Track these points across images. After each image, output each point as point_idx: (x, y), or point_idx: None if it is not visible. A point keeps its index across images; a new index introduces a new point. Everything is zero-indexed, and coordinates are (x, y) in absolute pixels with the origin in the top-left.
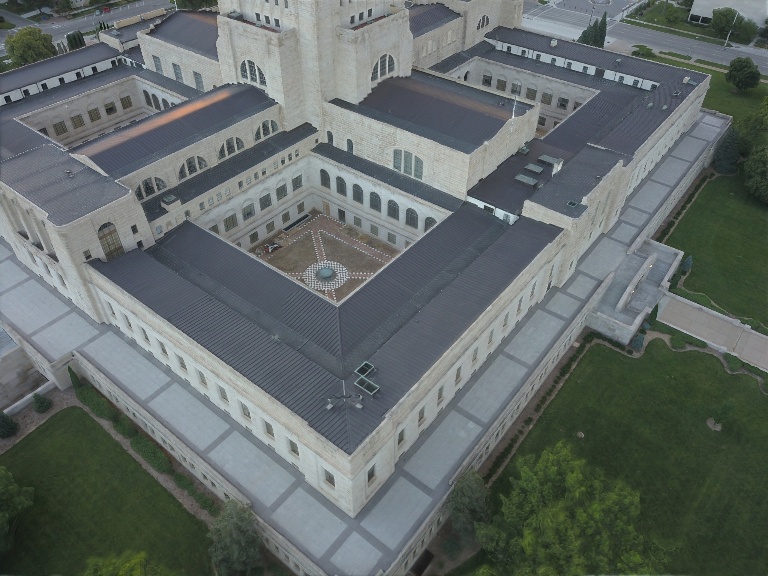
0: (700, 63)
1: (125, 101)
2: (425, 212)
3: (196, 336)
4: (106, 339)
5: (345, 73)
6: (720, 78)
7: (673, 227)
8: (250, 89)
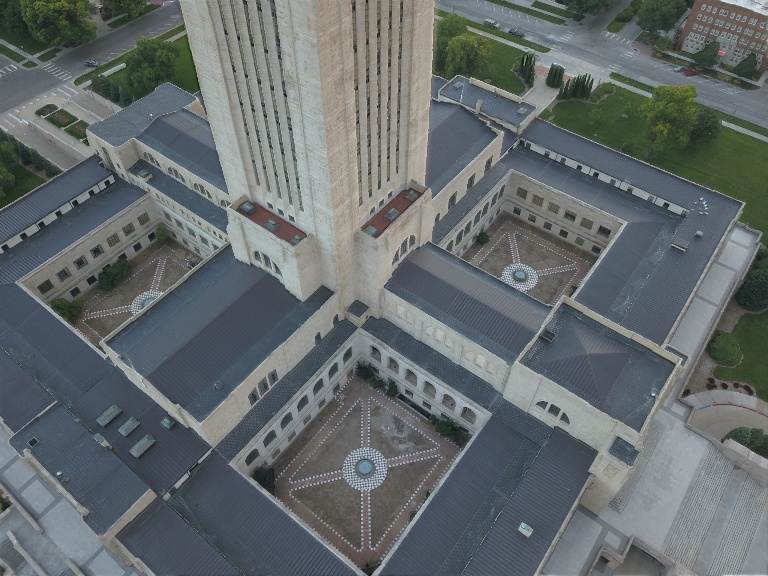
0: None
1: None
2: None
3: (5, 214)
4: None
5: None
6: None
7: None
8: None
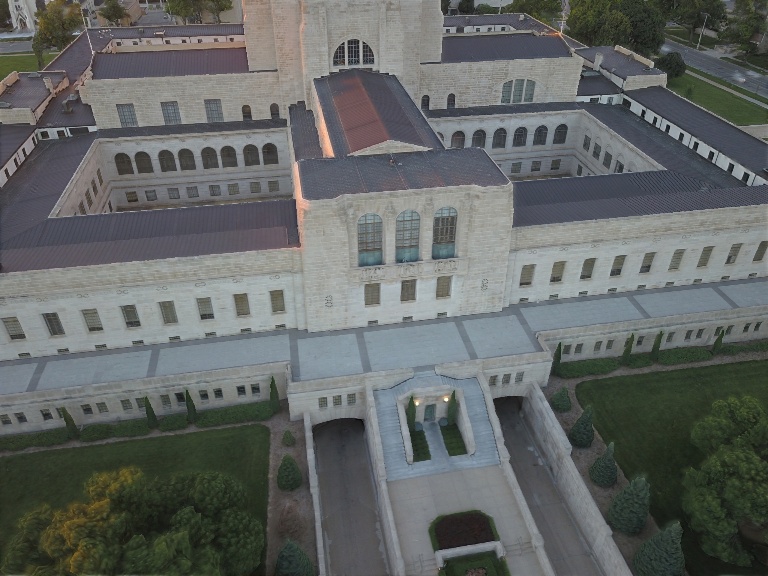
0: None
1: None
2: (557, 122)
3: None
4: (531, 314)
5: (429, 32)
6: None
7: None
8: (359, 71)
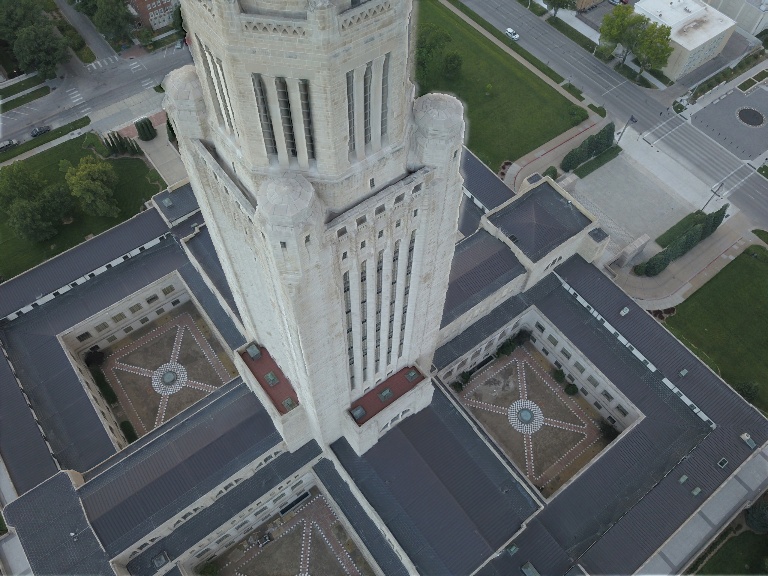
0: None
1: (167, 289)
2: None
3: None
4: None
5: None
6: None
7: None
8: (260, 413)
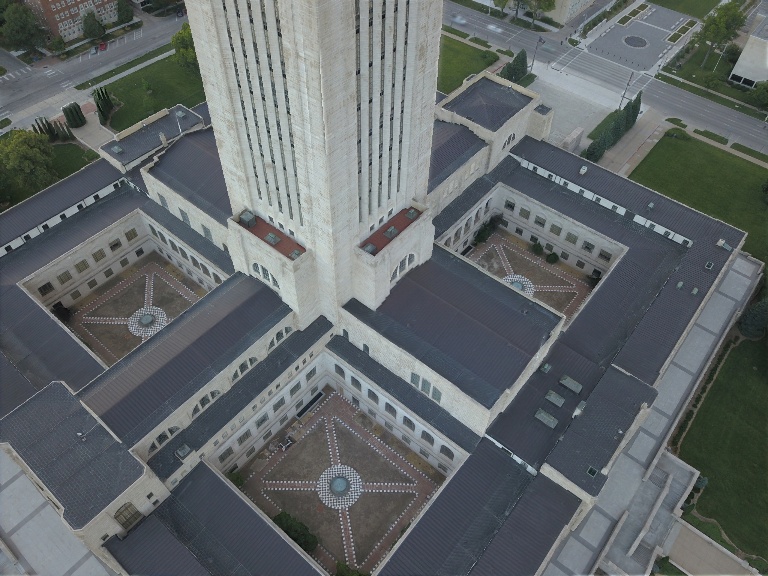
0: (737, 150)
1: (130, 233)
2: (442, 442)
3: None
4: None
5: (363, 285)
6: (756, 177)
7: (691, 420)
8: (263, 290)
